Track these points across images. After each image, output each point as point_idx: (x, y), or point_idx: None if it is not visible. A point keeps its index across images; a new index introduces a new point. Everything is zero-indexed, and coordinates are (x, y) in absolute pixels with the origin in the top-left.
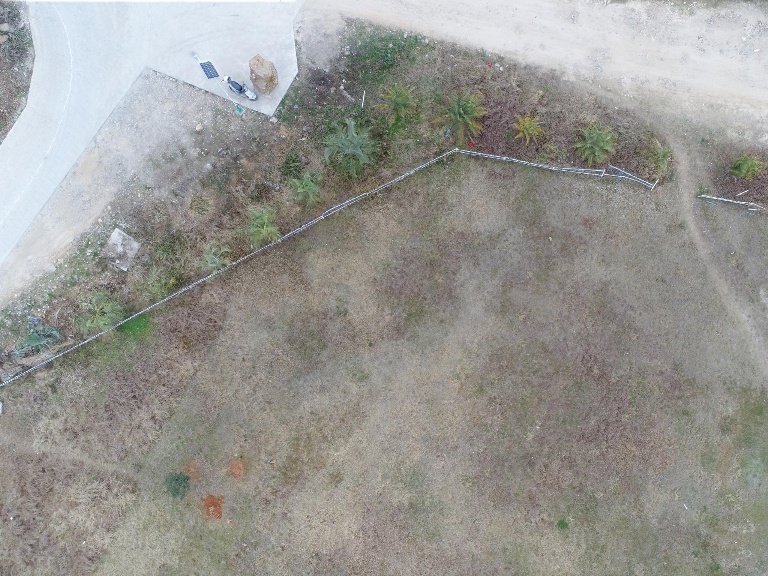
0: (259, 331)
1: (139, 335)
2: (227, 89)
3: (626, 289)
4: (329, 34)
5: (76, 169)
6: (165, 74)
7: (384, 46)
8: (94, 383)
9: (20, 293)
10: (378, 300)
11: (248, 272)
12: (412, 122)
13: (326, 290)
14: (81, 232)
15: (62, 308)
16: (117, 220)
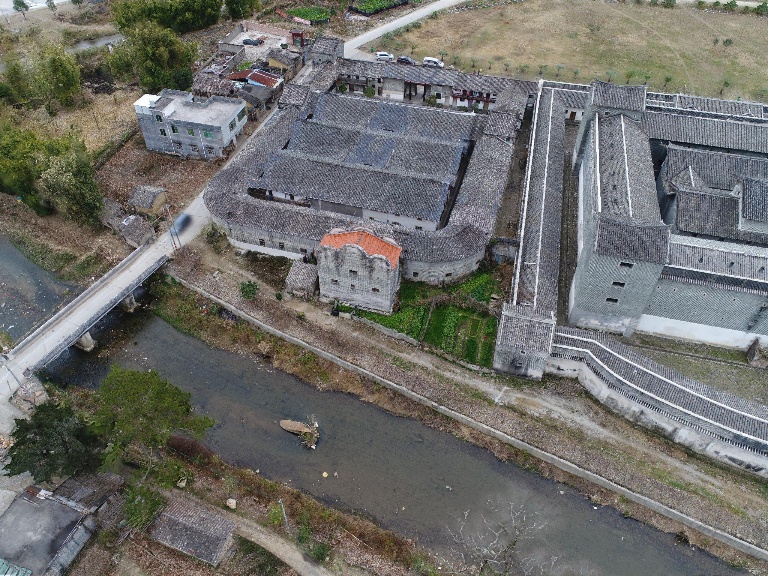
0: (514, 9)
1: (488, 8)
2: None
3: (593, 8)
4: None
5: None
6: None
7: None
8: None
9: (464, 1)
10: (539, 7)
11: (511, 4)
12: None
13: (528, 6)
14: None
15: (472, 4)
16: None
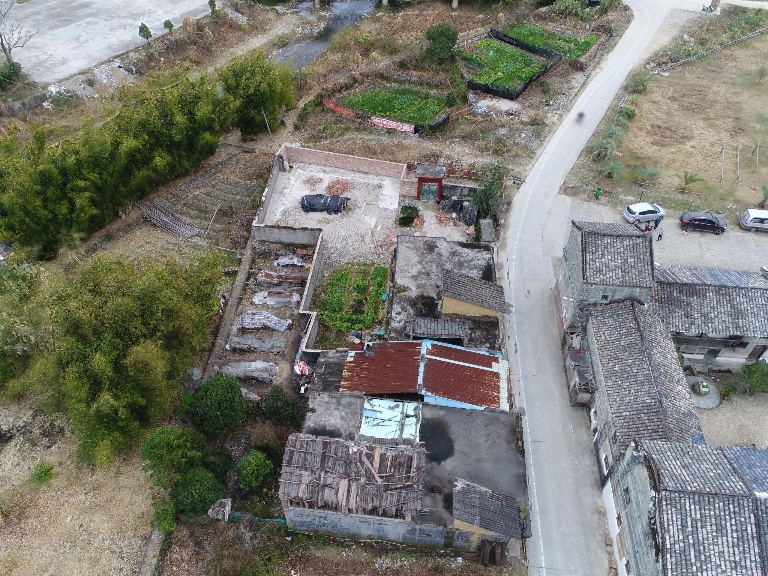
0: None
1: None
2: (701, 11)
3: None
4: (723, 4)
5: (661, 26)
6: (679, 9)
7: (742, 7)
8: (699, 69)
9: (659, 49)
10: None
11: None
12: (762, 20)
13: (766, 49)
14: (672, 37)
15: None
16: (683, 34)
